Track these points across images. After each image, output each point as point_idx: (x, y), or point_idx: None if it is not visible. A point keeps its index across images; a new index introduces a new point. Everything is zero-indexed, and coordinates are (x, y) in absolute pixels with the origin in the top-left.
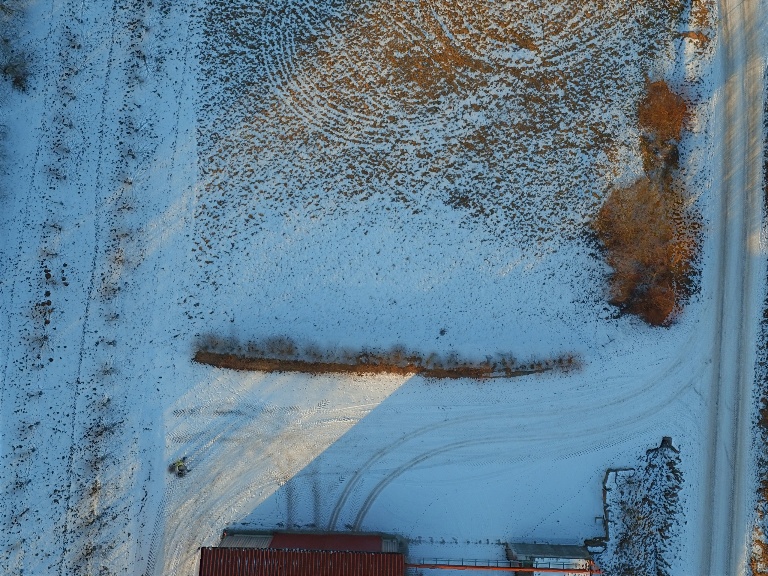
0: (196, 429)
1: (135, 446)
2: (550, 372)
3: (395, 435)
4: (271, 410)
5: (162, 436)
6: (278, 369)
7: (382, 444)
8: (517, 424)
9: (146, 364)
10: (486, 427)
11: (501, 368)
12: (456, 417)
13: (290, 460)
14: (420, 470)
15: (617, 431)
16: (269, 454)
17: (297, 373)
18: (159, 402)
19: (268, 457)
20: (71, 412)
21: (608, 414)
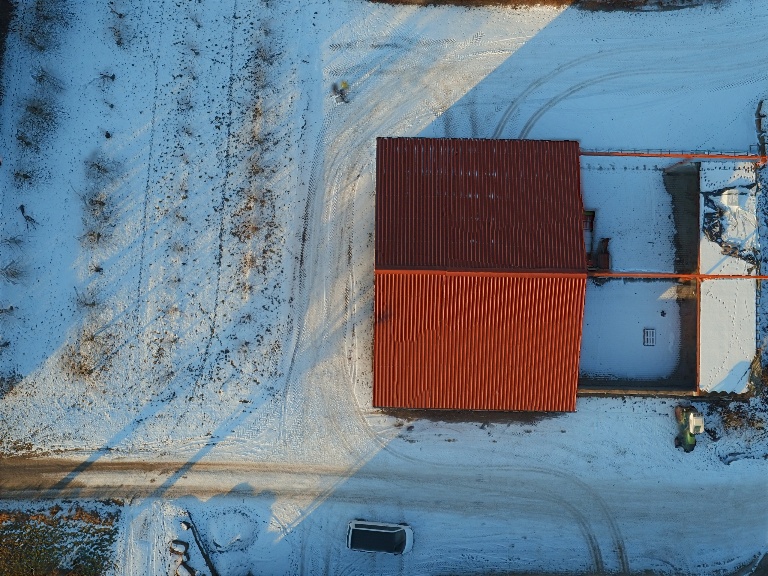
0: (352, 62)
1: (293, 76)
2: (700, 8)
3: (550, 66)
4: (427, 43)
5: (319, 69)
6: (433, 3)
7: (537, 75)
8: (669, 57)
9: (301, 0)
10: (639, 59)
11: (652, 2)
12: (609, 49)
13: (446, 91)
14: (576, 99)
15: (767, 66)
16: (425, 86)
17: (452, 7)
18: (315, 37)
19: (424, 88)
20: (229, 45)
21: (758, 50)
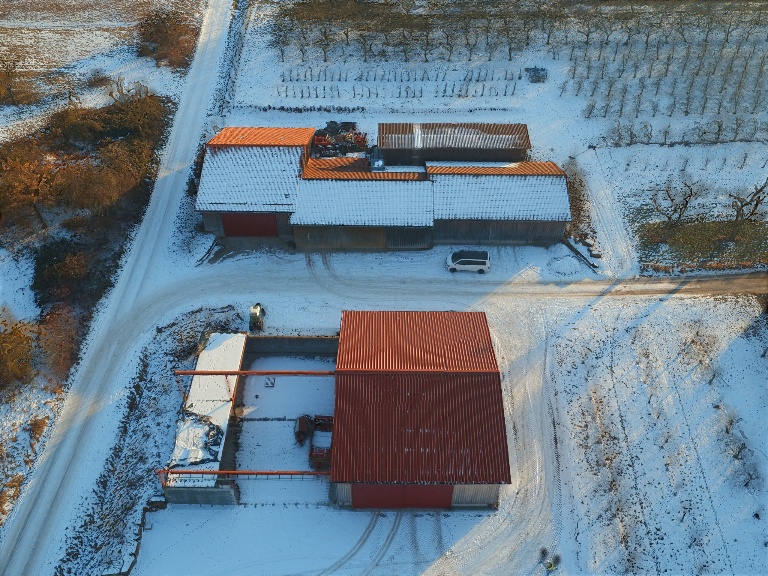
0: None
1: None
2: None
3: None
4: None
5: None
6: None
7: None
8: None
9: None
10: None
11: None
12: None
13: (443, 575)
14: (315, 569)
15: None
16: None
17: None
18: None
19: None
20: None
21: None
